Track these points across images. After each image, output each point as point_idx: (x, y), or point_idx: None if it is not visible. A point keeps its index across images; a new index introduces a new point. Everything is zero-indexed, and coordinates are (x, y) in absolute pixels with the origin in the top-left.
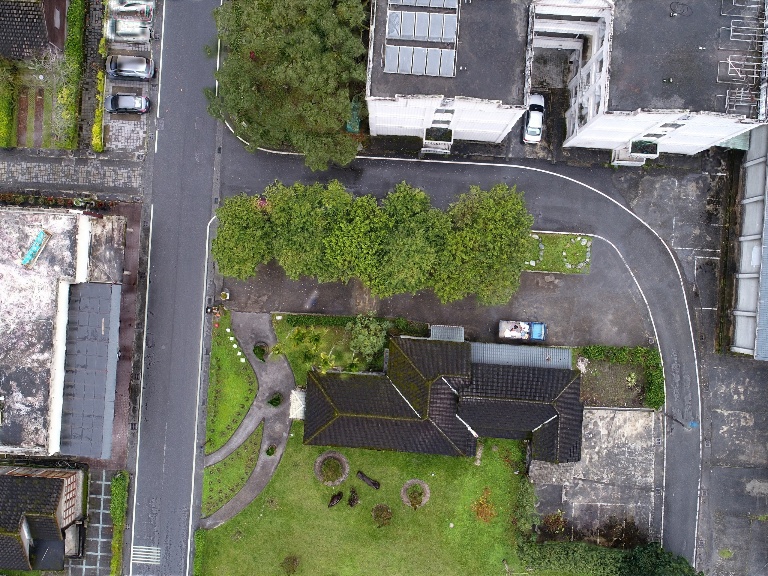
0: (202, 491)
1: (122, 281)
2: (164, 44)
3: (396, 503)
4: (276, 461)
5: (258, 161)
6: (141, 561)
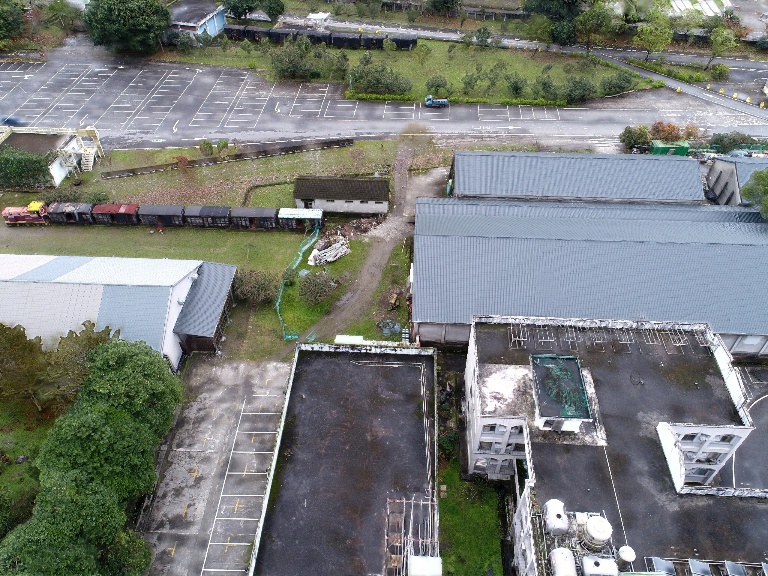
0: None
1: None
2: None
3: None
4: None
5: None
6: None
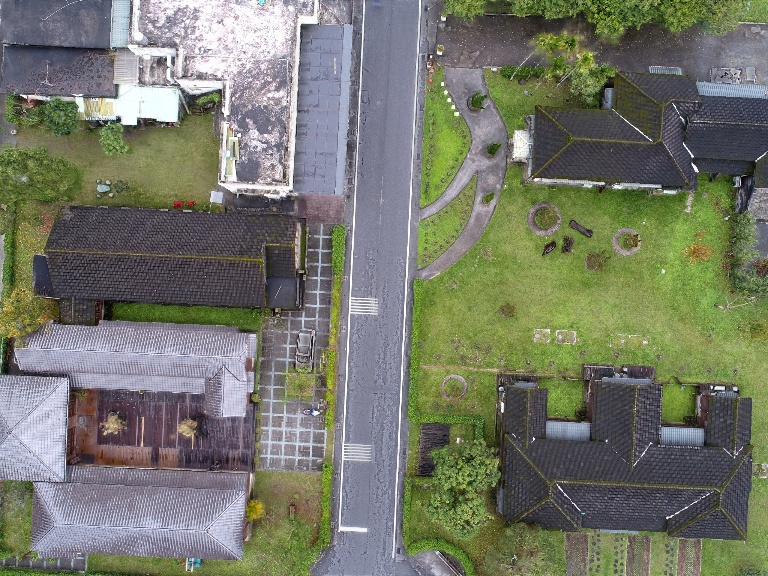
0: (418, 243)
1: (350, 24)
2: None
3: (608, 251)
4: (490, 213)
5: None
6: (359, 312)
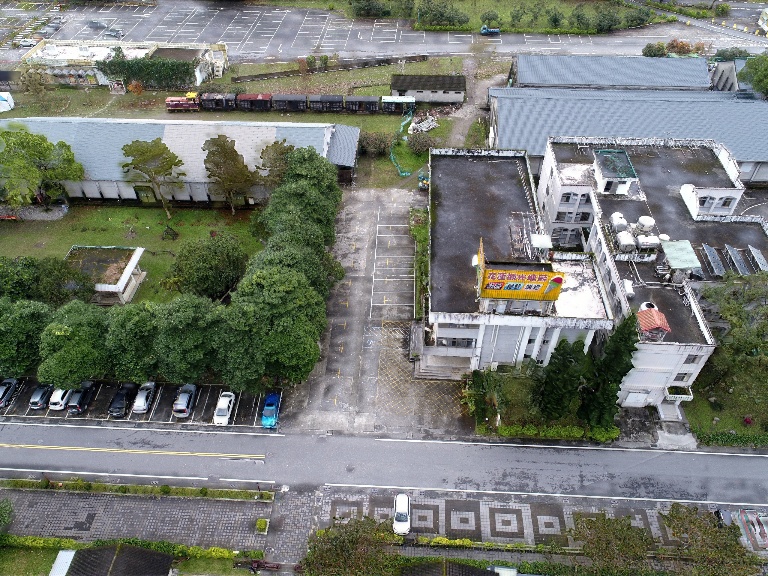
0: None
1: None
2: (767, 503)
3: None
4: None
5: None
6: None
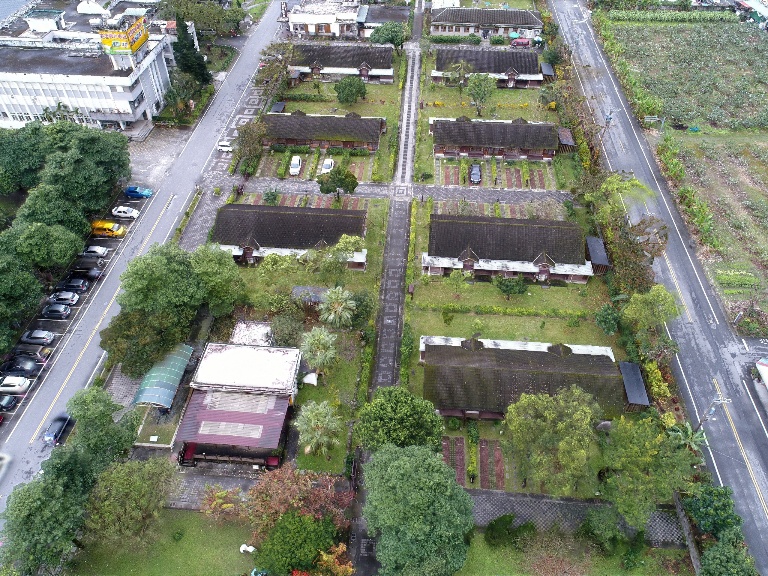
0: None
1: None
2: (258, 64)
3: None
4: None
5: None
6: None
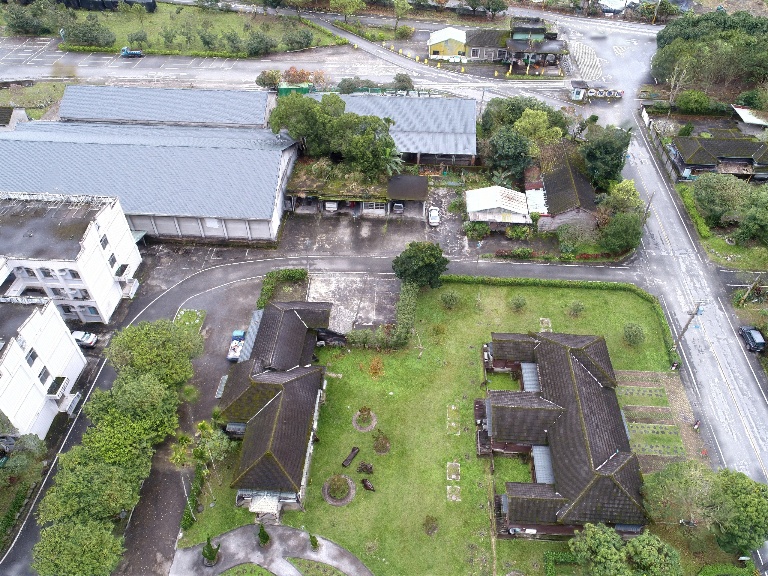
0: None
1: None
2: None
3: None
4: (328, 544)
5: (14, 562)
6: None
